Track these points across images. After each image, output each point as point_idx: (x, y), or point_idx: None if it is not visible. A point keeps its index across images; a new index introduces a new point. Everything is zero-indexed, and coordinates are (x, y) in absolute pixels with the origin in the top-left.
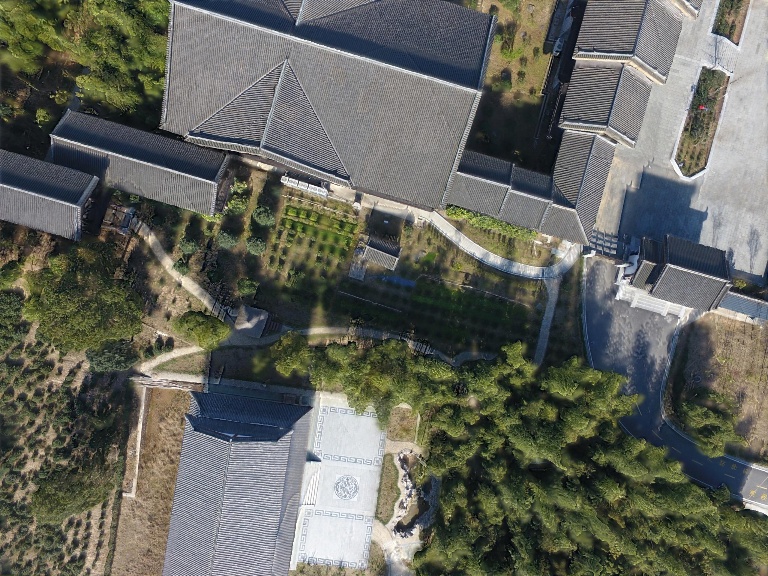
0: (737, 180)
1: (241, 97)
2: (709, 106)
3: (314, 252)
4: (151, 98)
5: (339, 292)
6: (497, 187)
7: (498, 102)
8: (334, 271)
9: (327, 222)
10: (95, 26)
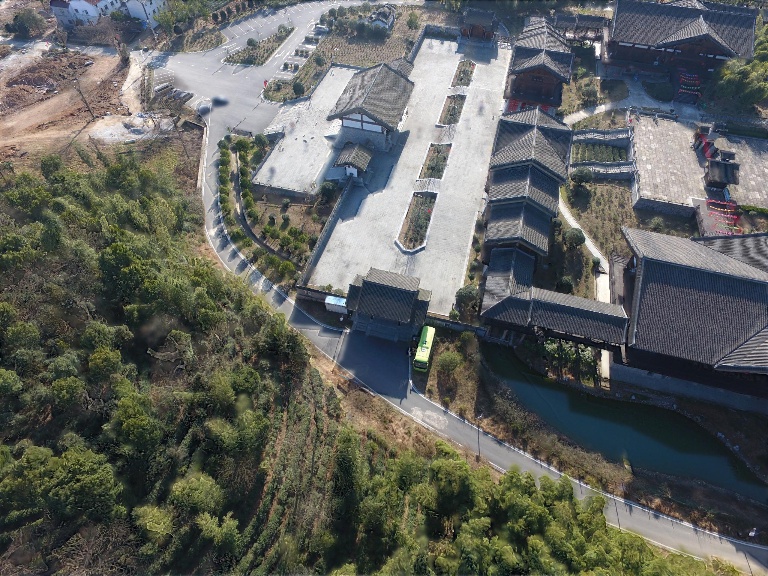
0: None
1: None
2: None
3: None
4: None
5: None
6: None
7: None
8: None
9: None
10: None
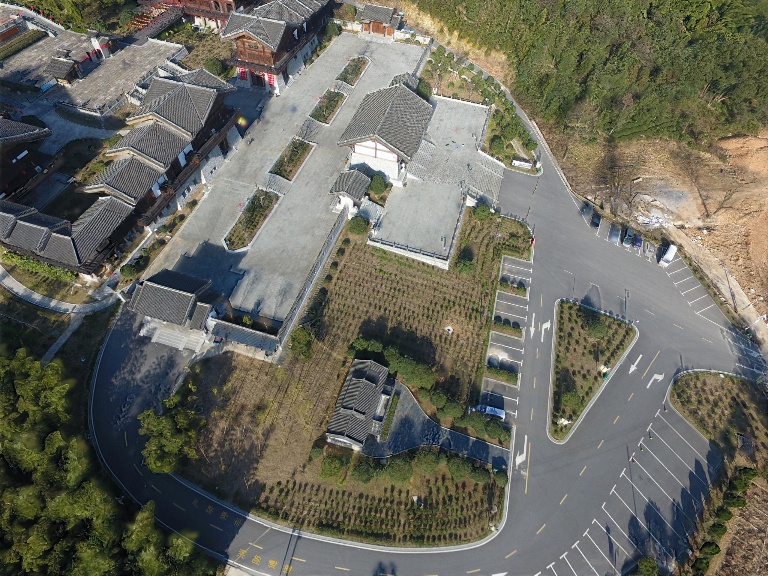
0: (275, 255)
1: None
2: (259, 210)
3: None
4: None
5: None
6: (5, 217)
7: (89, 199)
8: None
9: None
10: None
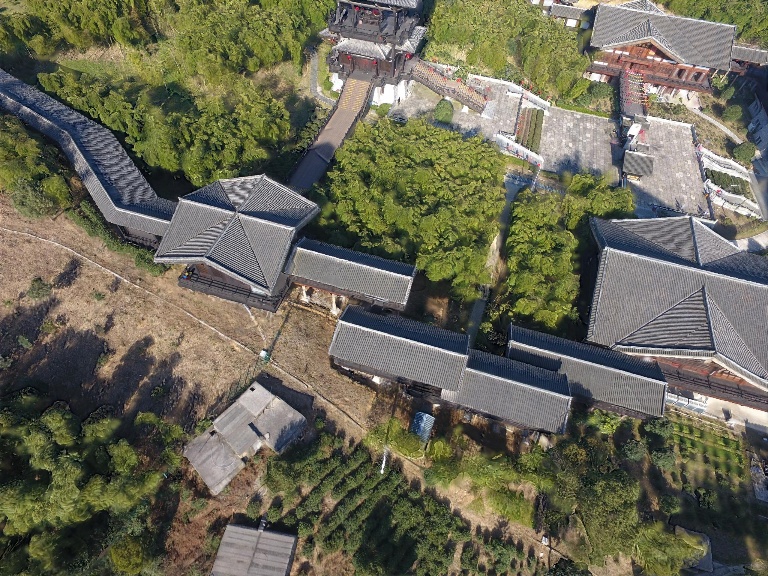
0: None
1: (664, 315)
2: None
3: (711, 470)
4: (557, 320)
5: (760, 516)
6: None
7: None
8: (740, 492)
9: (710, 438)
10: (522, 266)
